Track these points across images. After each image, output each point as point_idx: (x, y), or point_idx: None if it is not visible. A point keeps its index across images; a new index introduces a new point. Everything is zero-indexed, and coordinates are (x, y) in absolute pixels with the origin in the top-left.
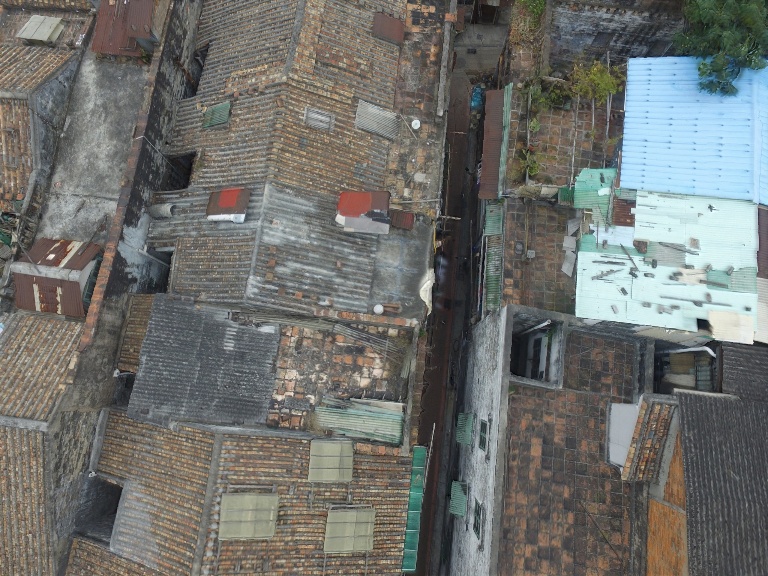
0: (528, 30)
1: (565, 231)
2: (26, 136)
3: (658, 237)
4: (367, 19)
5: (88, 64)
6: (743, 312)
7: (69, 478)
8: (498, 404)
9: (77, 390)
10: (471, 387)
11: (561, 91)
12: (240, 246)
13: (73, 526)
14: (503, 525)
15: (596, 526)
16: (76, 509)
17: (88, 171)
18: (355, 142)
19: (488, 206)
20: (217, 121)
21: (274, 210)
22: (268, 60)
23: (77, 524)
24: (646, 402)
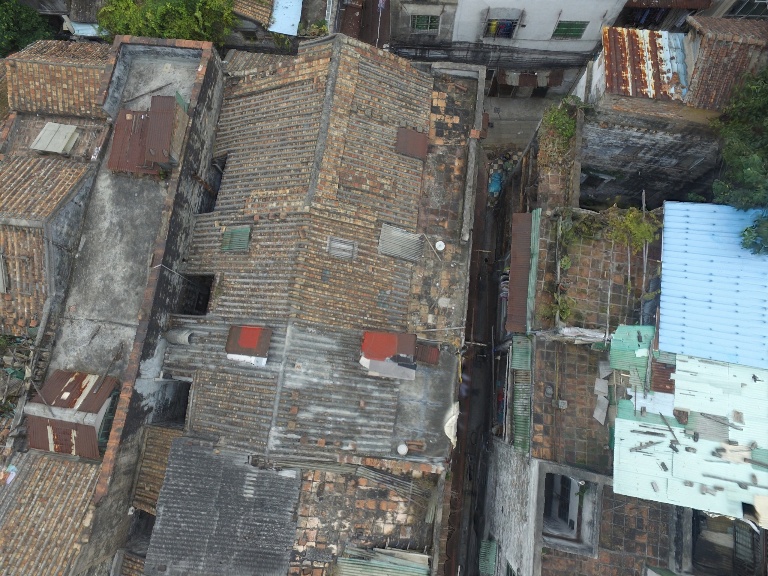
0: (556, 151)
1: (596, 373)
2: (41, 263)
3: (699, 407)
4: (390, 135)
5: (104, 178)
6: None
7: None
8: (529, 569)
9: (92, 546)
10: (493, 506)
11: (592, 223)
12: (261, 389)
13: None
14: None
15: None
16: None
17: (103, 294)
18: (378, 269)
19: (515, 337)
20: (236, 246)
21: (296, 351)
22: (289, 183)
23: None
24: None
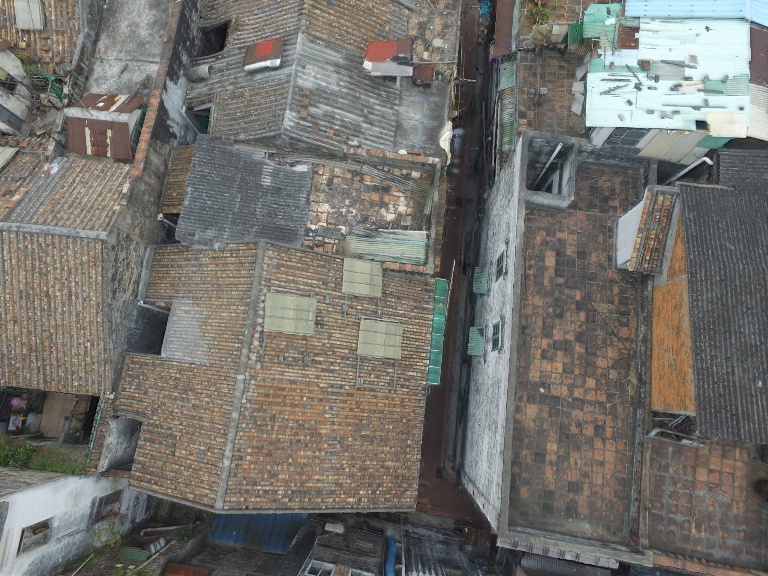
0: None
1: (574, 78)
2: (74, 1)
3: (660, 56)
4: None
5: None
6: (737, 112)
7: (122, 296)
8: (515, 219)
9: (129, 214)
10: (485, 251)
11: None
12: (275, 90)
13: (125, 345)
14: (521, 323)
15: (606, 323)
16: (127, 330)
17: (130, 38)
18: (378, 7)
19: (502, 64)
20: None
21: (306, 58)
22: None
23: (128, 345)
24: (650, 192)
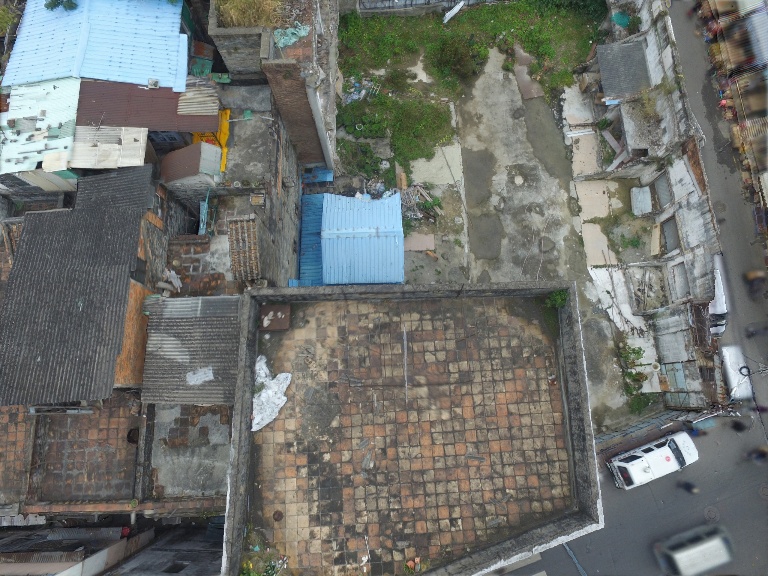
0: None
1: None
2: None
3: (22, 115)
4: None
5: None
6: (63, 150)
7: None
8: None
9: None
10: None
11: None
12: None
13: None
14: None
15: None
16: None
17: None
18: None
19: None
20: None
21: None
22: None
23: None
24: (1, 224)
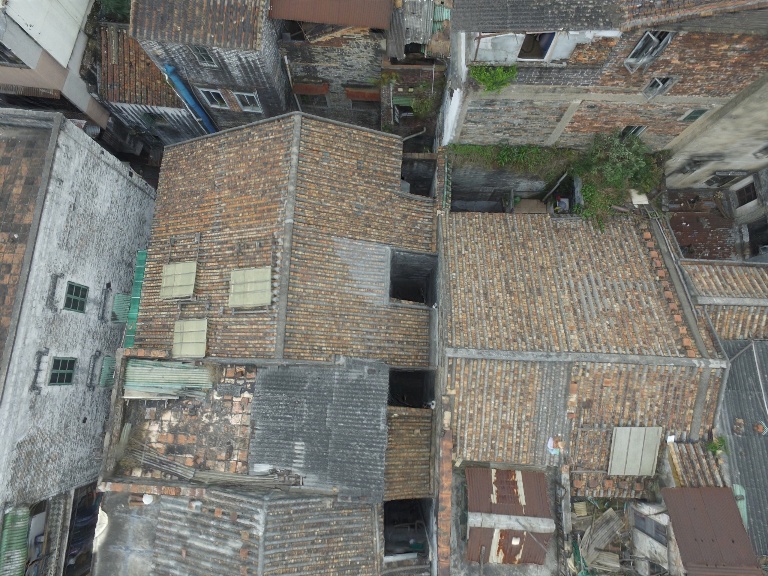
0: None
1: None
2: None
3: None
4: None
5: None
6: None
7: None
8: (10, 408)
9: None
10: None
11: None
12: (286, 572)
13: None
14: None
15: None
16: None
17: None
18: None
19: None
20: None
21: None
22: None
23: None
24: None
